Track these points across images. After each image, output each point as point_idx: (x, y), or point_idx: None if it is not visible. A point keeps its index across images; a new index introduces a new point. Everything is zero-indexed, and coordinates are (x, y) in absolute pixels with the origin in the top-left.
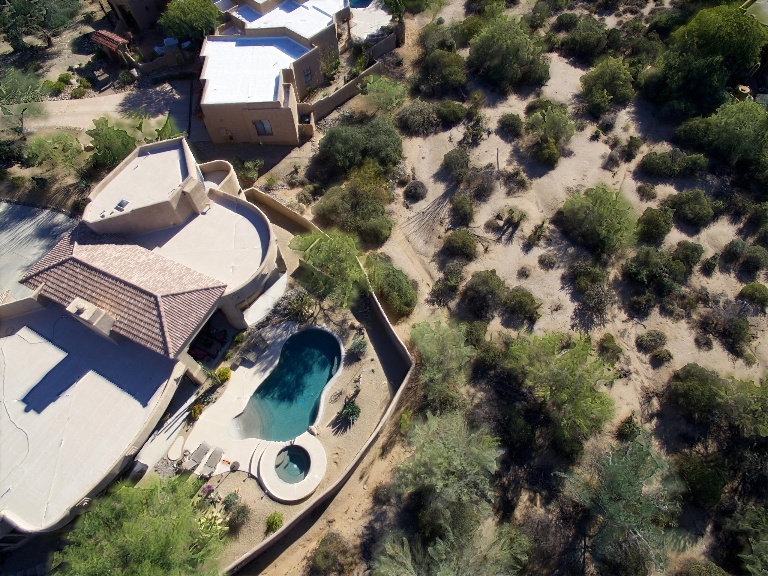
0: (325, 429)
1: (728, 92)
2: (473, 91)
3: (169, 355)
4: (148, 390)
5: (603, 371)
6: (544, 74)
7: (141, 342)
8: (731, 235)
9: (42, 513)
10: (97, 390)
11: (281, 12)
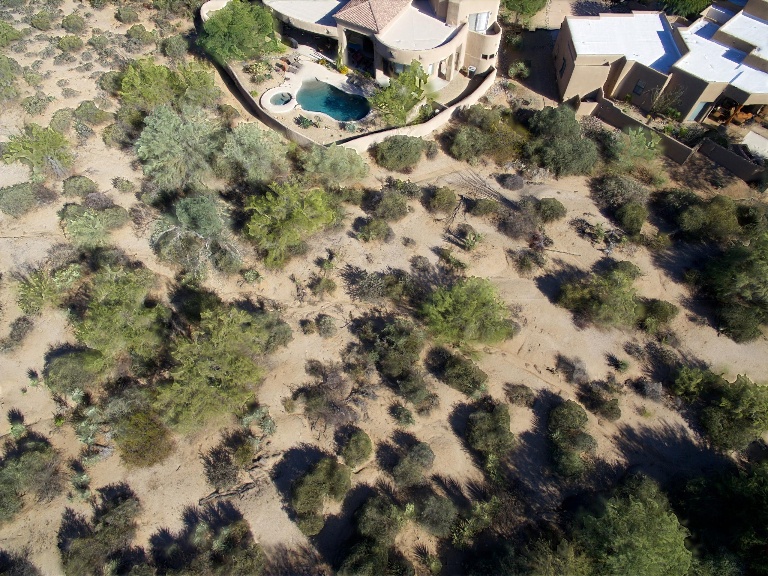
0: (299, 113)
1: (739, 572)
2: (683, 249)
3: (335, 14)
4: (325, 22)
5: (286, 233)
6: (733, 324)
7: (346, 5)
8: (451, 471)
9: (272, 1)
10: (329, 6)
11: (722, 51)
